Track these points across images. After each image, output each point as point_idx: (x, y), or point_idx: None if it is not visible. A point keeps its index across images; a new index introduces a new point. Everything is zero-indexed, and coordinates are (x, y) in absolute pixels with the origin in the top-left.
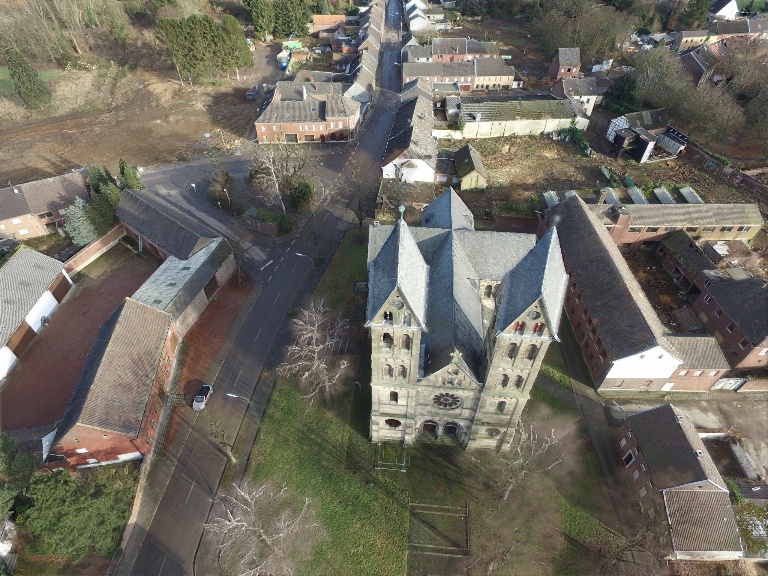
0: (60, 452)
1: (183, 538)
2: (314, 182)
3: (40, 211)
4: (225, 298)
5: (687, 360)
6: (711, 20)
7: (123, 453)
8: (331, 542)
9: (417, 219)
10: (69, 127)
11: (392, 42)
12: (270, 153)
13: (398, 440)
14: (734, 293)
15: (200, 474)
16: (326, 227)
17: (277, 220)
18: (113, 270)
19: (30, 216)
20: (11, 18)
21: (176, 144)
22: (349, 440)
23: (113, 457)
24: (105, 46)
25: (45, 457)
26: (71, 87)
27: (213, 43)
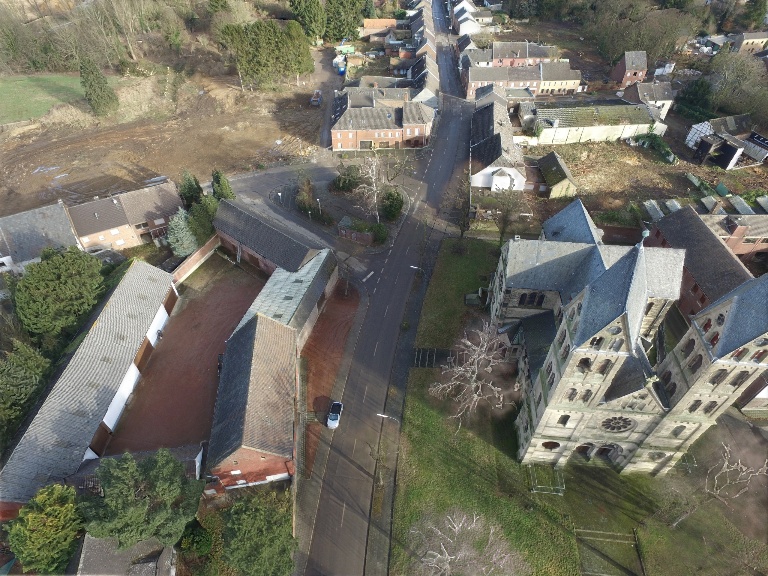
0: (216, 474)
1: (347, 564)
2: (397, 190)
3: (138, 221)
4: (334, 311)
5: None
6: (766, 21)
7: (273, 474)
8: (502, 570)
9: (525, 230)
10: (139, 134)
11: (444, 46)
12: (374, 163)
13: (549, 462)
14: None
15: (349, 496)
16: (420, 237)
17: (374, 230)
18: (215, 281)
19: (127, 226)
20: (72, 25)
21: (249, 151)
22: (497, 461)
23: (262, 478)
24: (159, 52)
25: (198, 478)
26: (133, 93)
27: (276, 49)
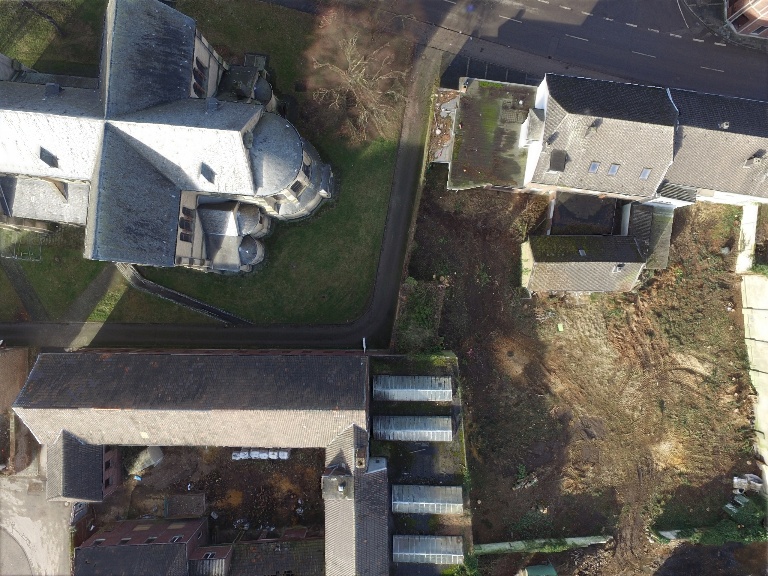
0: None
1: None
2: None
3: None
4: None
5: (51, 452)
6: None
7: None
8: None
9: None
10: None
11: None
12: None
13: None
14: (148, 570)
15: None
16: (414, 3)
17: None
18: None
19: None
20: None
21: None
22: (22, 60)
23: None
24: None
25: None
26: None
27: None
